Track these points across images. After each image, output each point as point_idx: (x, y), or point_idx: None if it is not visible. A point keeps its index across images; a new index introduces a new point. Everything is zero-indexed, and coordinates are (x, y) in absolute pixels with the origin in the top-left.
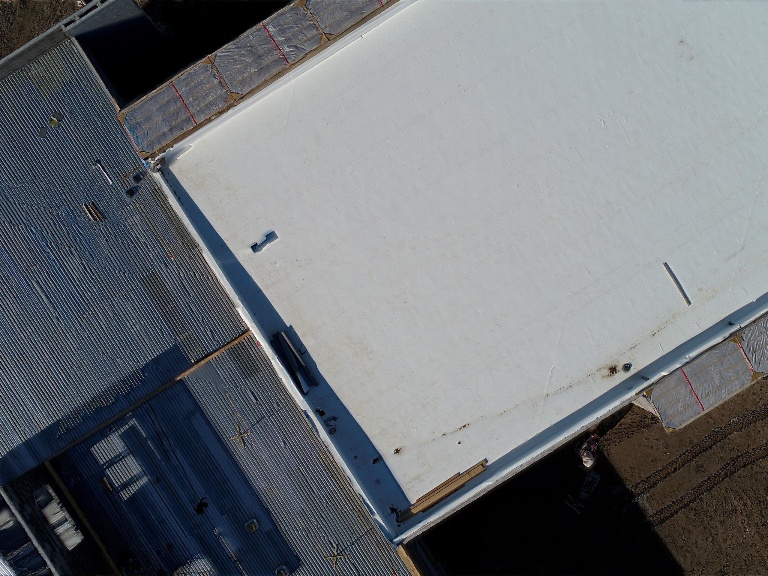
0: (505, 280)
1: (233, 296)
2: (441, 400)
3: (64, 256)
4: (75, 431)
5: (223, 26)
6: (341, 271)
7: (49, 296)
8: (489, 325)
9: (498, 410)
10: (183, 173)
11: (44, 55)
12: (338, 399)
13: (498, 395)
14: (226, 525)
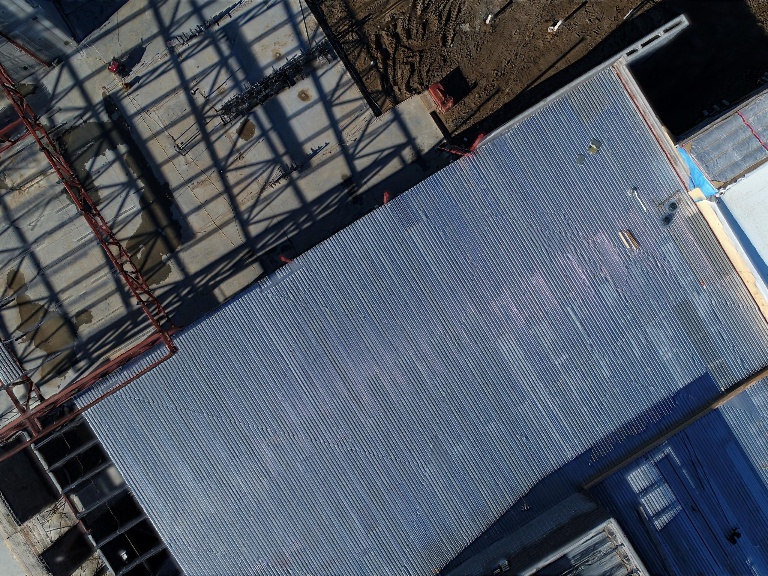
0: None
1: None
2: None
3: (599, 283)
4: (607, 459)
5: (687, 53)
6: None
7: (583, 323)
8: None
9: None
10: (733, 202)
11: (584, 83)
12: None
13: None
14: (758, 556)
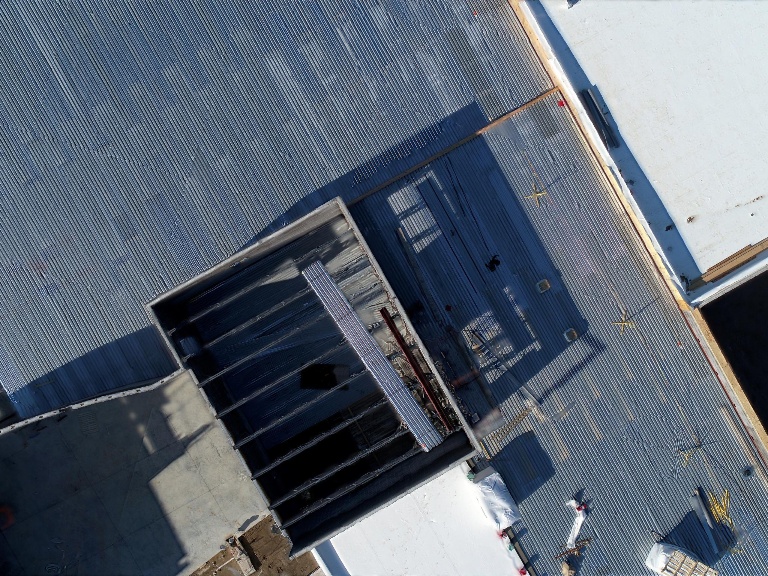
0: None
1: (546, 47)
2: (737, 170)
3: (370, 6)
4: (370, 182)
5: None
6: (648, 33)
7: (352, 45)
8: None
9: None
10: None
11: None
12: (636, 163)
13: None
14: (517, 284)
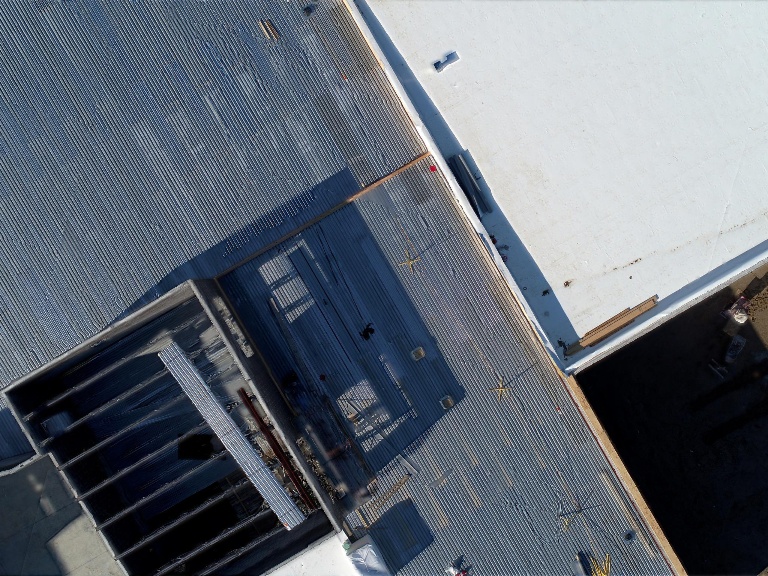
0: (685, 112)
1: (414, 114)
2: (614, 233)
3: (238, 72)
4: (242, 251)
5: None
6: (521, 96)
7: (221, 113)
8: (666, 158)
9: (671, 246)
10: None
11: None
12: (511, 227)
13: (672, 230)
14: (392, 352)
